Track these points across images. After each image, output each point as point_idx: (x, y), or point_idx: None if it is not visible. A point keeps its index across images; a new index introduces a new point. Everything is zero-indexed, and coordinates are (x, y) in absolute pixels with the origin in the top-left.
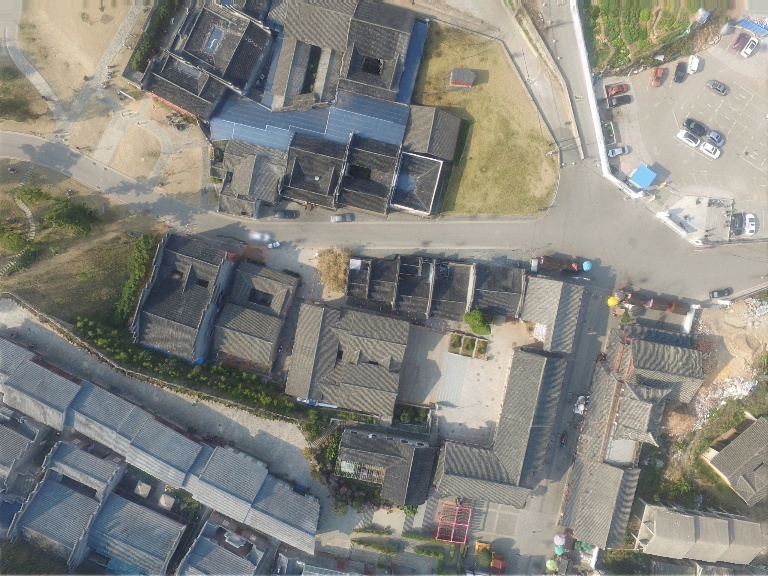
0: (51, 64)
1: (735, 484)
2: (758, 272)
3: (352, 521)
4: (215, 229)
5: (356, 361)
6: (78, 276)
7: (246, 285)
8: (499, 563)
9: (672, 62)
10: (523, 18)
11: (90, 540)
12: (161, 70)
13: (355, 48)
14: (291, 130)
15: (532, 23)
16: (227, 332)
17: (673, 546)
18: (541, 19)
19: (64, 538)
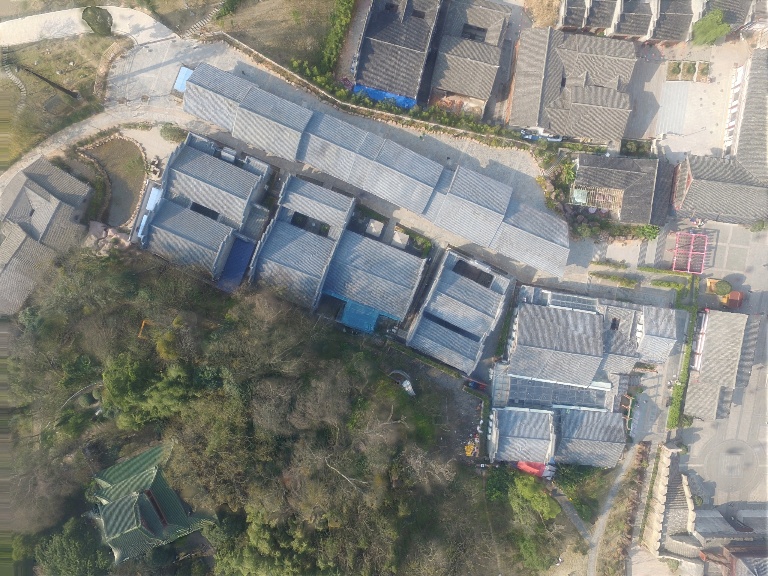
0: None
1: None
2: None
3: (589, 253)
4: None
5: (583, 84)
6: (284, 22)
7: (460, 19)
8: (737, 294)
9: None
10: None
11: (328, 279)
12: None
13: None
14: None
15: None
16: (450, 60)
17: None
18: None
19: (307, 270)
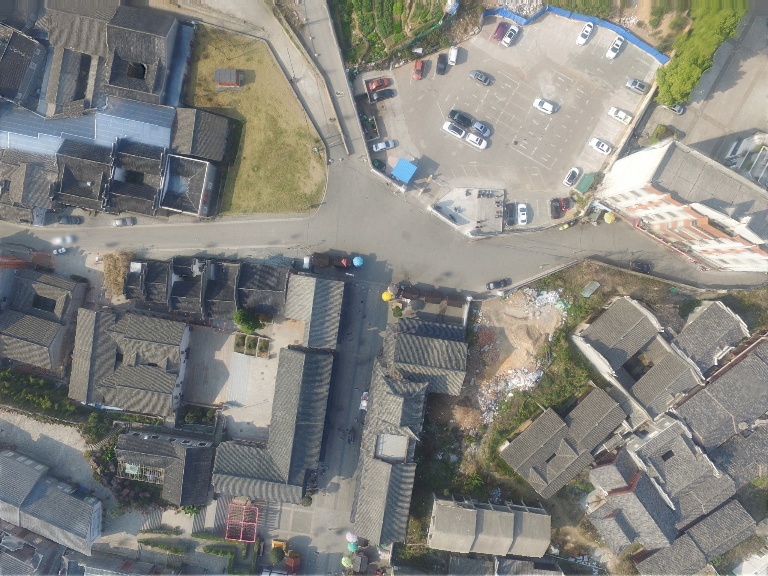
0: None
1: (527, 476)
2: (536, 262)
3: (138, 522)
4: (5, 237)
5: (134, 363)
6: None
7: (28, 291)
8: (291, 561)
9: (434, 54)
10: (280, 17)
11: None
12: None
13: (116, 53)
14: (62, 137)
15: (286, 21)
16: (5, 338)
17: (455, 540)
18: (296, 17)
19: None
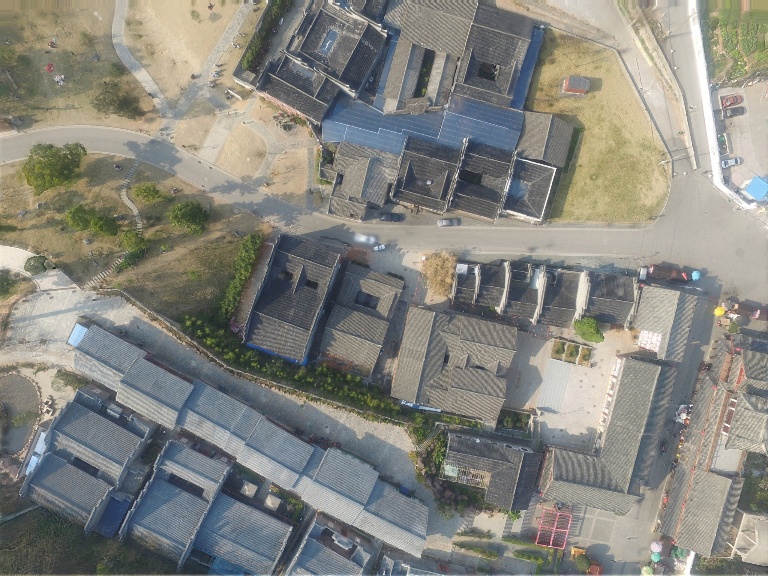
0: (157, 61)
1: None
2: None
3: (455, 525)
4: (319, 230)
5: (463, 365)
6: (185, 275)
7: (353, 287)
8: (596, 569)
9: None
10: (641, 27)
11: (197, 539)
12: (277, 70)
13: (473, 53)
14: (404, 133)
15: (651, 33)
16: (336, 334)
17: None
18: (660, 29)
19: (175, 537)
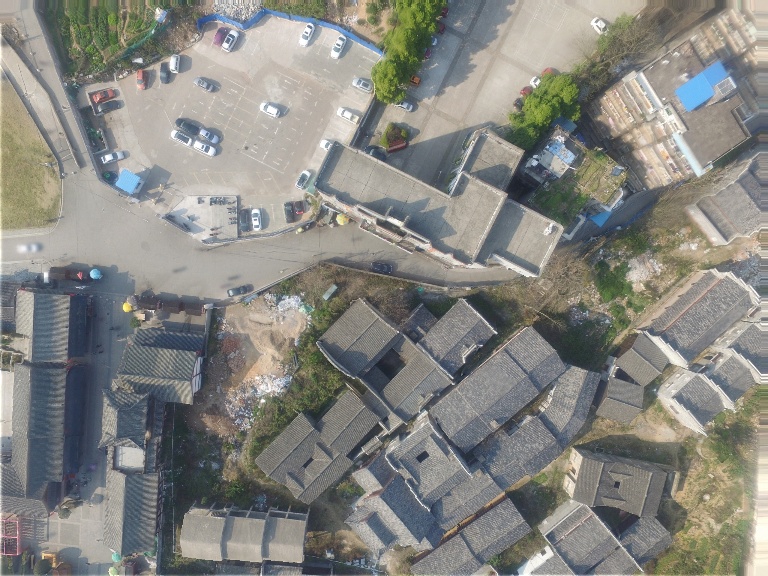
0: None
1: (284, 482)
2: (276, 267)
3: None
4: None
5: None
6: None
7: None
8: (56, 573)
9: (158, 63)
10: None
11: None
12: None
13: None
14: None
15: (4, 38)
16: None
17: (203, 549)
18: (16, 33)
19: None
